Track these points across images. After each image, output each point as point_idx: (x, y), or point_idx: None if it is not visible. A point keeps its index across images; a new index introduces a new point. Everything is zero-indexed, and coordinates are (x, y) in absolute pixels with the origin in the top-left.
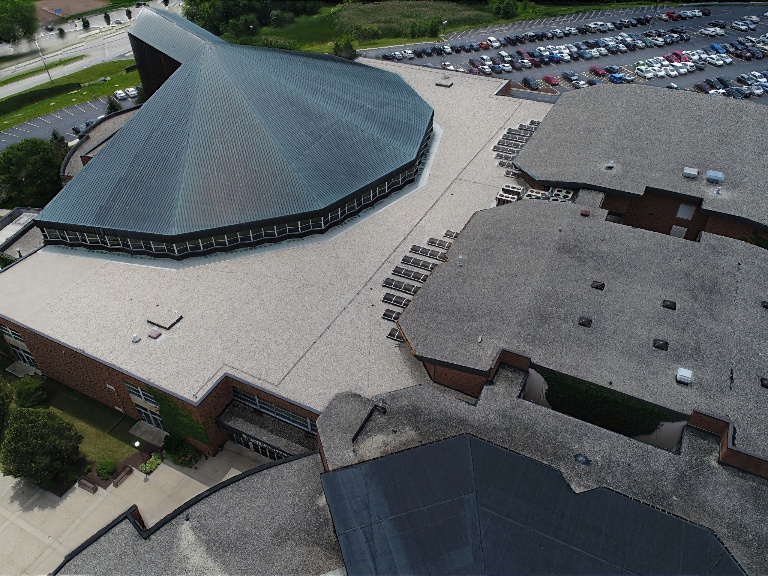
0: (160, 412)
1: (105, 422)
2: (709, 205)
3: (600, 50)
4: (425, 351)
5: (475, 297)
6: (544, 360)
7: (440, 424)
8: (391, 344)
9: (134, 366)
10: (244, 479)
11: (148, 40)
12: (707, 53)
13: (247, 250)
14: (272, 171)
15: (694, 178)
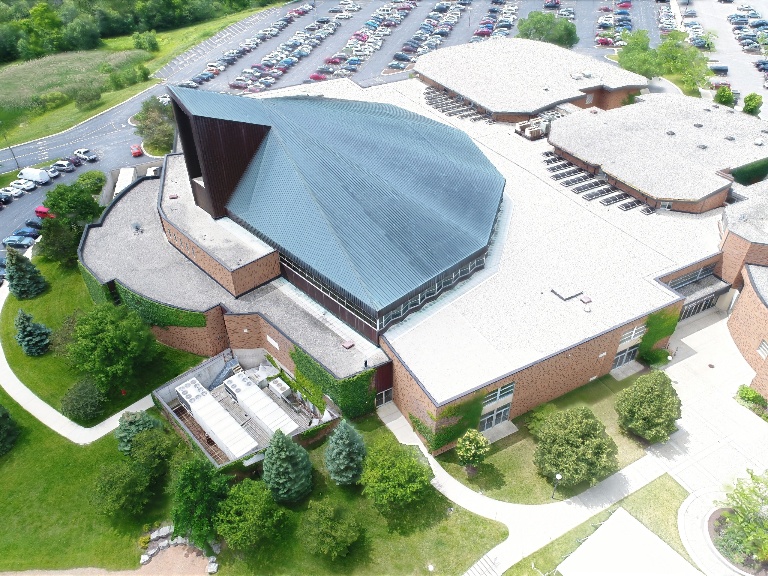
0: (646, 336)
1: (600, 392)
2: (612, 86)
3: (306, 47)
4: (697, 196)
5: (654, 167)
6: (730, 166)
7: (760, 212)
8: (655, 216)
9: (622, 317)
10: (762, 296)
11: (219, 116)
12: (370, 29)
13: (496, 236)
14: (453, 171)
15: (580, 78)
